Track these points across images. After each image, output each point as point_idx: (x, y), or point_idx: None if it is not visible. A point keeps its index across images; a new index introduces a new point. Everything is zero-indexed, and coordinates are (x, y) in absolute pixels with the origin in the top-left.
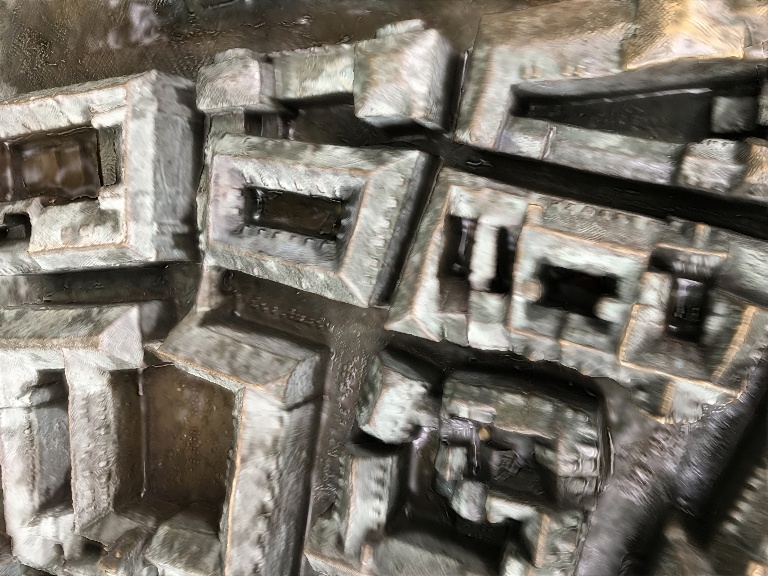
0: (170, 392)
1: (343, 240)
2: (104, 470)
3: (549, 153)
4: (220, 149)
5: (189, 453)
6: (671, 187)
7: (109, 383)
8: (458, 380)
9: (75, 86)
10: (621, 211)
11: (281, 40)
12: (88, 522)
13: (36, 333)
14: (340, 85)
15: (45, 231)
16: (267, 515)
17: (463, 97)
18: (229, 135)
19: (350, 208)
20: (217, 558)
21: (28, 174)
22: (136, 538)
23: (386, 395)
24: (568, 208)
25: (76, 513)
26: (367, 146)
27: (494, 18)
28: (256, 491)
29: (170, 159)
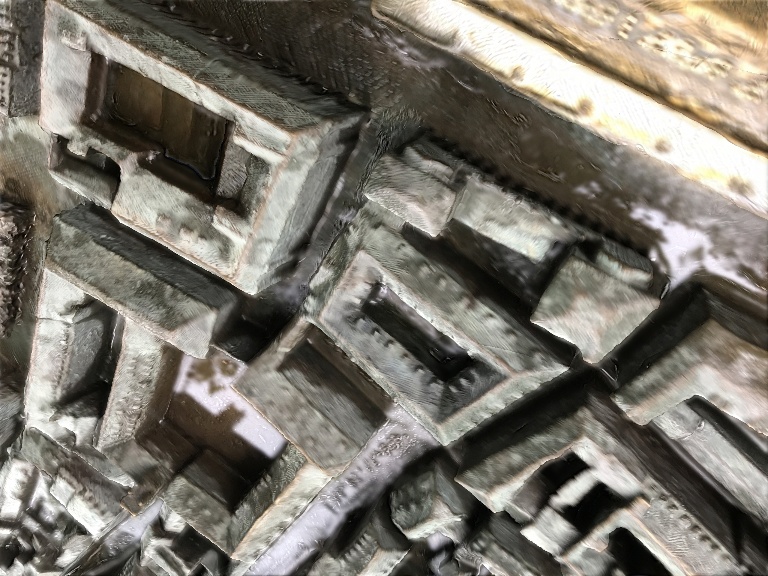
0: (214, 358)
1: (454, 396)
2: (136, 411)
3: (683, 439)
4: (369, 244)
5: (215, 410)
6: (761, 522)
7: (162, 349)
8: (494, 538)
9: (223, 74)
10: (711, 534)
11: (481, 124)
12: (110, 444)
13: (99, 283)
14: (526, 249)
15: (137, 200)
16: (282, 528)
17: (644, 373)
18: (383, 227)
19: (476, 375)
20: (225, 530)
21: (121, 90)
22: (156, 485)
23: (429, 521)
24: (671, 510)
25: (102, 438)
26: (521, 328)
27: (724, 335)
28: (281, 515)
29: (305, 201)
